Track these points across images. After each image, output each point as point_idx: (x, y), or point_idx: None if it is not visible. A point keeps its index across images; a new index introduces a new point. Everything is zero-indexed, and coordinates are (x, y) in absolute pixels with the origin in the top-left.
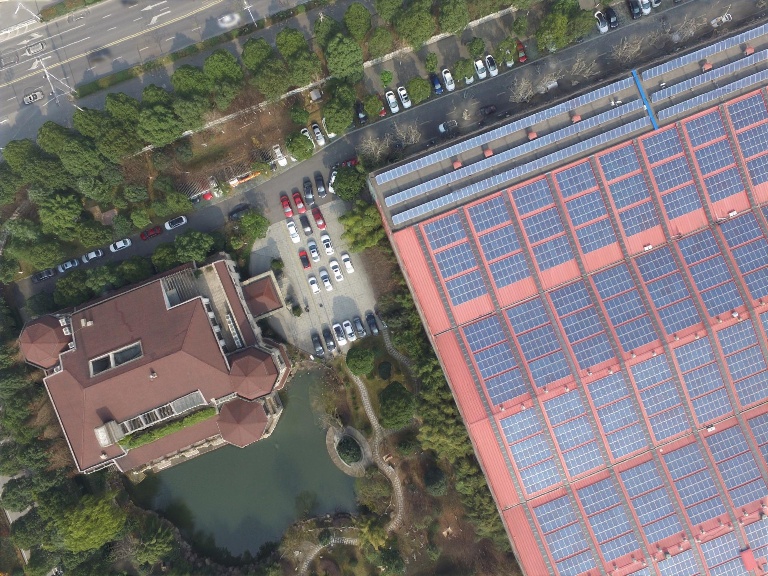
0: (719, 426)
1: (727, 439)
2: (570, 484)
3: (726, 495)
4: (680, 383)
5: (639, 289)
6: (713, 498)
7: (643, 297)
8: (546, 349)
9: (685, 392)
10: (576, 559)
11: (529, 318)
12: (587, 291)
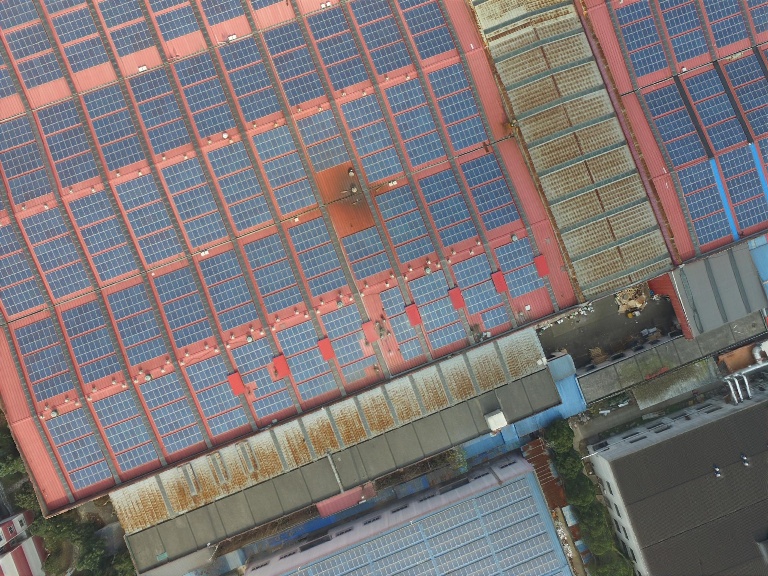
0: (214, 251)
1: (220, 263)
2: (55, 306)
3: (215, 319)
4: (170, 205)
5: (130, 109)
6: (201, 321)
7: (134, 117)
8: (28, 167)
9: (177, 215)
10: (53, 381)
11: (13, 136)
12: (76, 110)
